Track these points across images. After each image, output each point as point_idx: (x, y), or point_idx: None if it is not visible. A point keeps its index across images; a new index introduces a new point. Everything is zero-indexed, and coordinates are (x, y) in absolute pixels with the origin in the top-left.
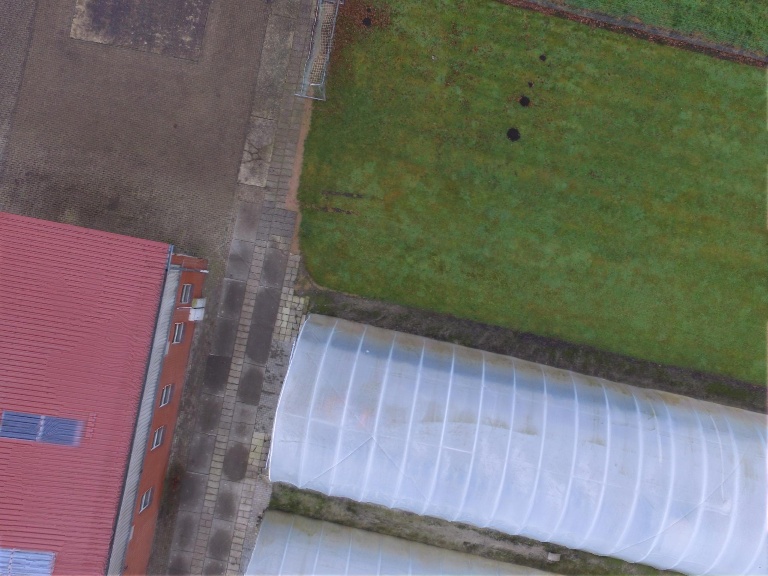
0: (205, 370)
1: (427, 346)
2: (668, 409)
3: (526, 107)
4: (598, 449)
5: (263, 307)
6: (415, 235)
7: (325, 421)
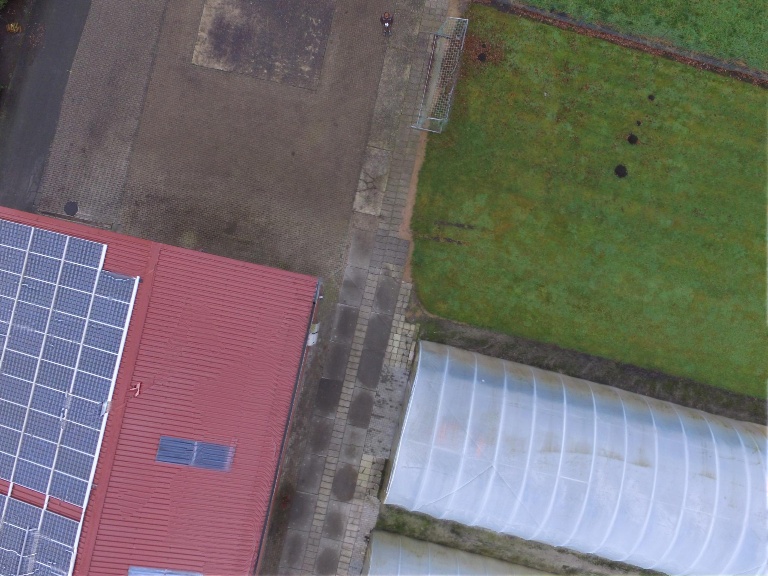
0: (317, 393)
1: (536, 376)
2: None
3: (634, 145)
4: (708, 482)
5: (375, 333)
6: (523, 266)
7: (447, 449)
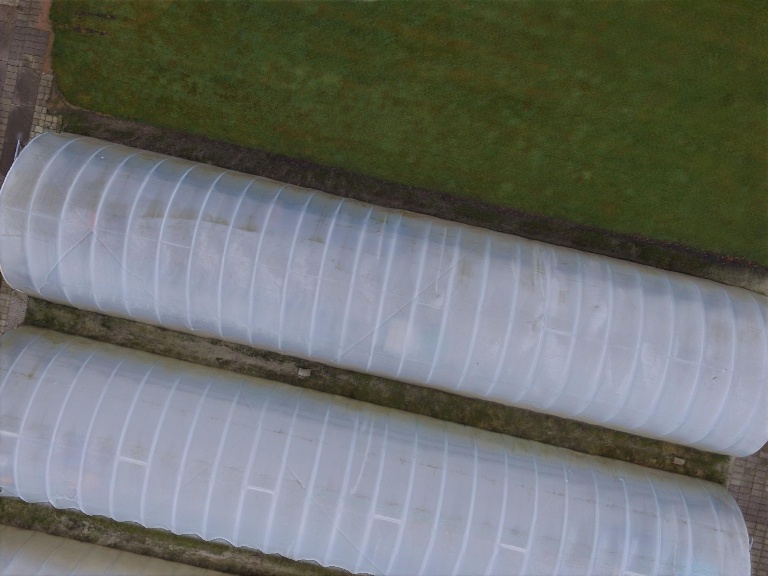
0: None
1: (171, 160)
2: (402, 218)
3: None
4: (317, 246)
5: (16, 125)
6: (168, 56)
7: (46, 216)
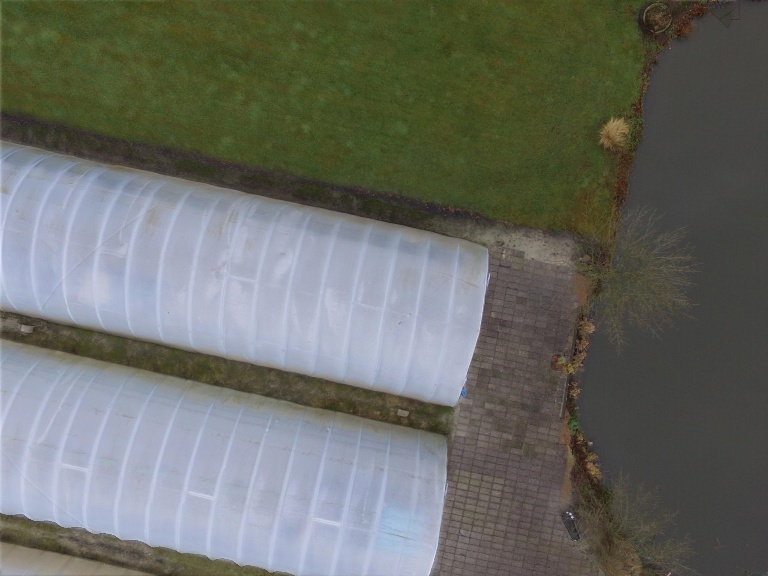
0: None
1: None
2: (104, 172)
3: None
4: (2, 197)
5: None
6: None
7: None
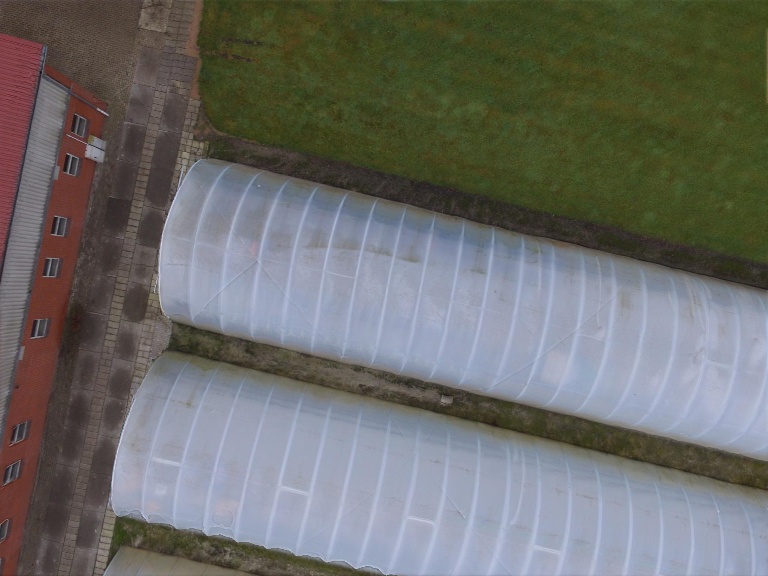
0: (105, 213)
1: (322, 187)
2: (554, 248)
3: None
4: (479, 277)
5: (163, 151)
6: (314, 83)
7: (211, 245)
